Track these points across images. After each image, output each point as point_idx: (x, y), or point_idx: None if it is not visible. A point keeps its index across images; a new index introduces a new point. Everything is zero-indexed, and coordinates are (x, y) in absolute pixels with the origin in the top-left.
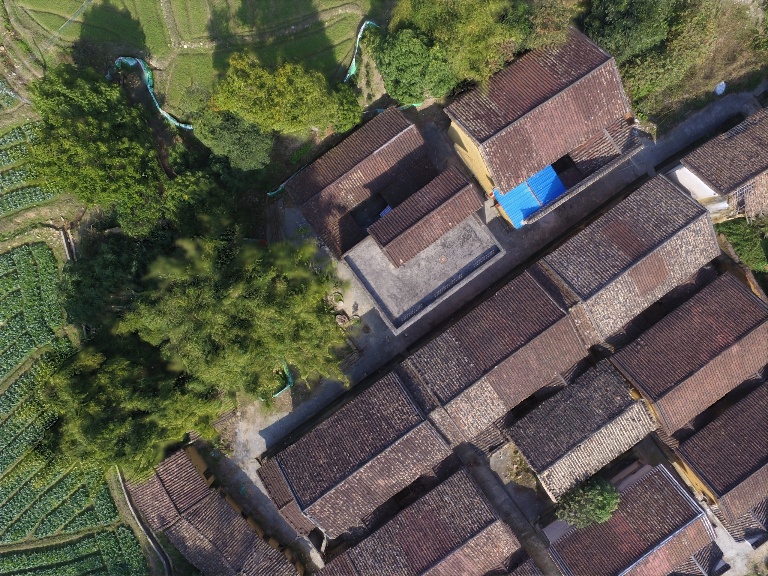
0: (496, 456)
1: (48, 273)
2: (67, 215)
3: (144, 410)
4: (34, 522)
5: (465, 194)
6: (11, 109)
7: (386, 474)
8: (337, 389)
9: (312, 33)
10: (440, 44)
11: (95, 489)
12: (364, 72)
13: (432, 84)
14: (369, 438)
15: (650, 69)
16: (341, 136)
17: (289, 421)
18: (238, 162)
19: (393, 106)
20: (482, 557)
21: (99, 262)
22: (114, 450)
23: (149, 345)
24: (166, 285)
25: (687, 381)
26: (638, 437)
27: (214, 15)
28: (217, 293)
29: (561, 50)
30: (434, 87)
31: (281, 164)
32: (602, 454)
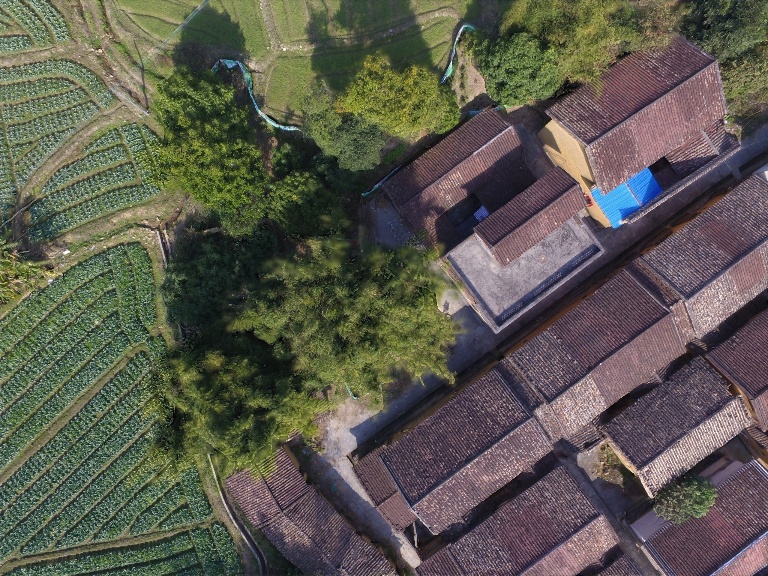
0: (583, 453)
1: (143, 273)
2: (163, 215)
3: (264, 407)
4: (130, 520)
5: (572, 194)
6: (109, 111)
7: (490, 470)
8: (428, 387)
9: (408, 36)
10: (553, 47)
11: (190, 487)
12: (459, 75)
13: (540, 86)
14: (475, 435)
15: (746, 72)
16: (437, 137)
17: (380, 419)
18: (349, 163)
19: (485, 108)
20: (583, 552)
21: (203, 262)
22: (240, 446)
23: (260, 343)
24: (271, 284)
25: None
26: (733, 433)
27: (313, 18)
28: (343, 291)
29: (662, 53)
30: (540, 89)
31: None
32: (698, 450)
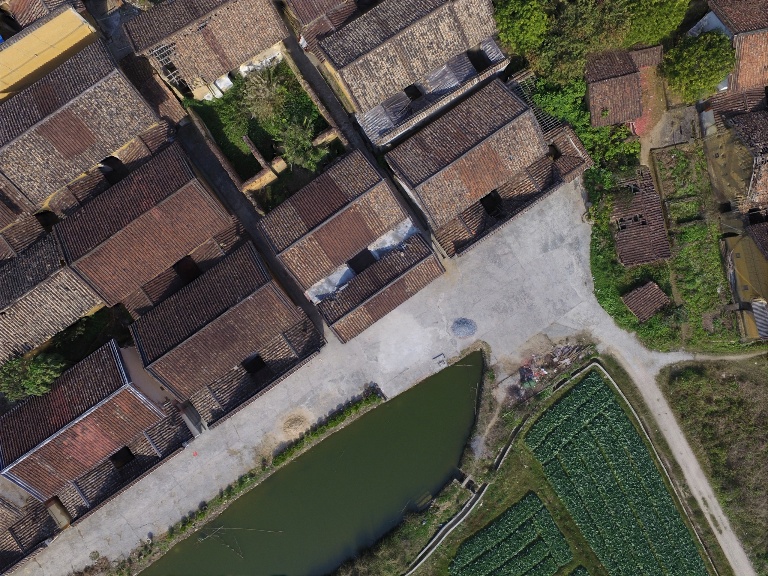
0: None
1: None
2: None
3: None
4: None
5: None
6: None
7: None
8: None
9: None
10: None
11: None
12: None
13: None
14: None
15: None
16: None
17: None
18: None
19: None
20: None
21: None
22: None
23: None
24: None
25: (106, 245)
26: (82, 309)
27: None
28: None
29: None
30: None
31: None
32: (40, 325)
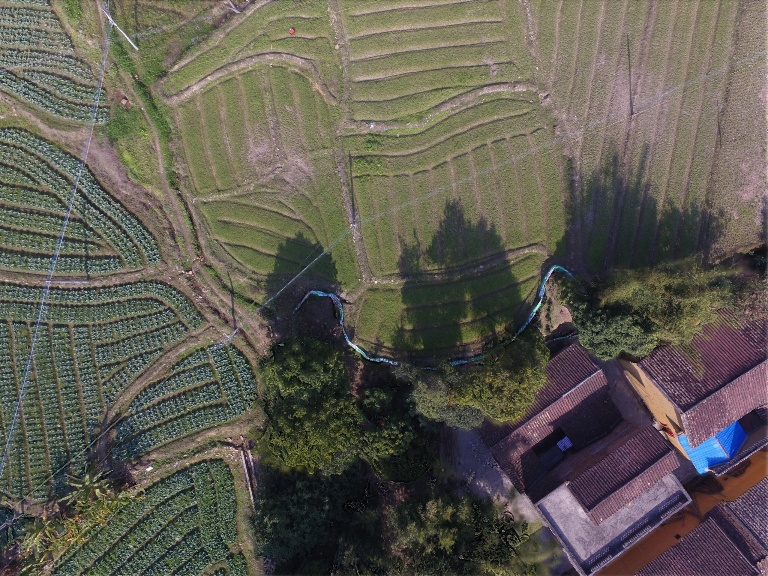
0: None
1: (226, 491)
2: (247, 434)
3: None
4: None
5: (666, 458)
6: (197, 332)
7: None
8: None
9: (498, 270)
10: (657, 329)
11: None
12: (545, 306)
13: None
14: None
15: None
16: None
17: None
18: (448, 424)
19: (569, 335)
20: None
21: (293, 500)
22: None
23: None
24: (362, 528)
25: None
26: None
27: (405, 253)
28: None
29: None
30: None
31: None
32: None
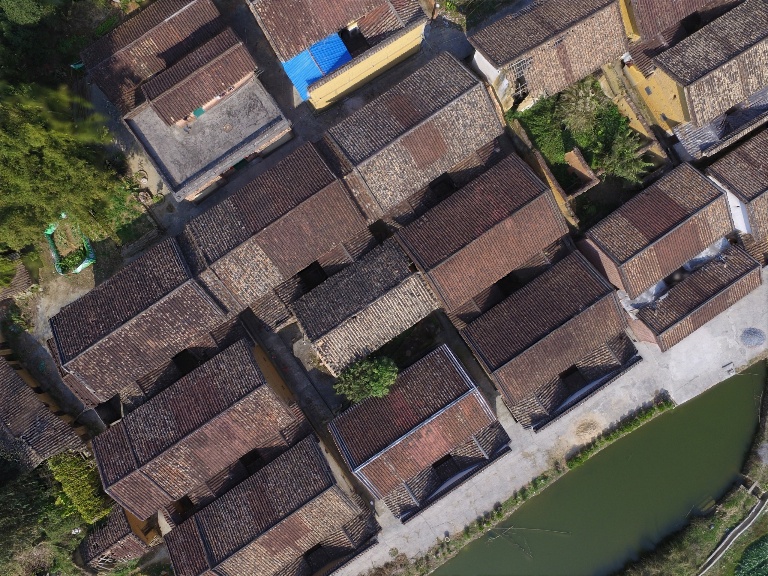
0: (299, 342)
1: None
2: None
3: None
4: None
5: (236, 53)
6: None
7: (155, 335)
8: None
9: None
10: None
11: None
12: None
13: None
14: (138, 297)
15: None
16: None
17: None
18: (9, 12)
19: None
20: (253, 425)
21: None
22: None
23: None
24: None
25: (460, 253)
26: (420, 314)
27: None
28: None
29: None
30: None
31: (88, 39)
32: (382, 329)
